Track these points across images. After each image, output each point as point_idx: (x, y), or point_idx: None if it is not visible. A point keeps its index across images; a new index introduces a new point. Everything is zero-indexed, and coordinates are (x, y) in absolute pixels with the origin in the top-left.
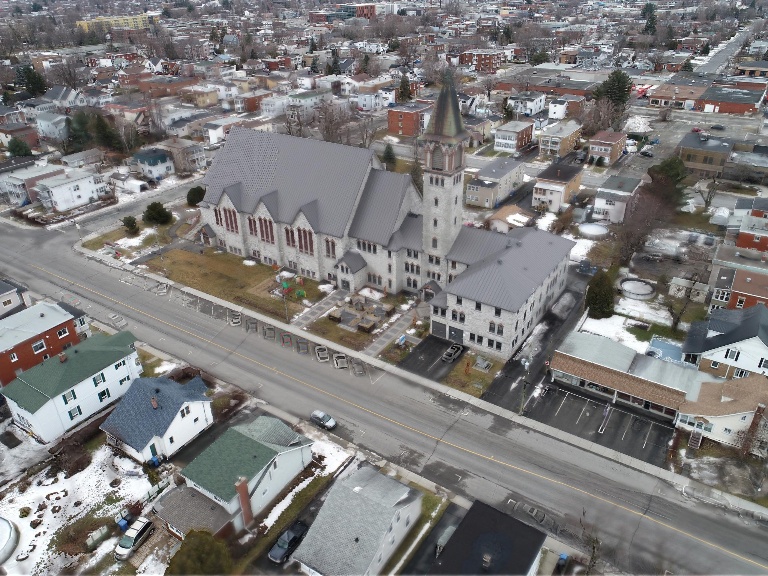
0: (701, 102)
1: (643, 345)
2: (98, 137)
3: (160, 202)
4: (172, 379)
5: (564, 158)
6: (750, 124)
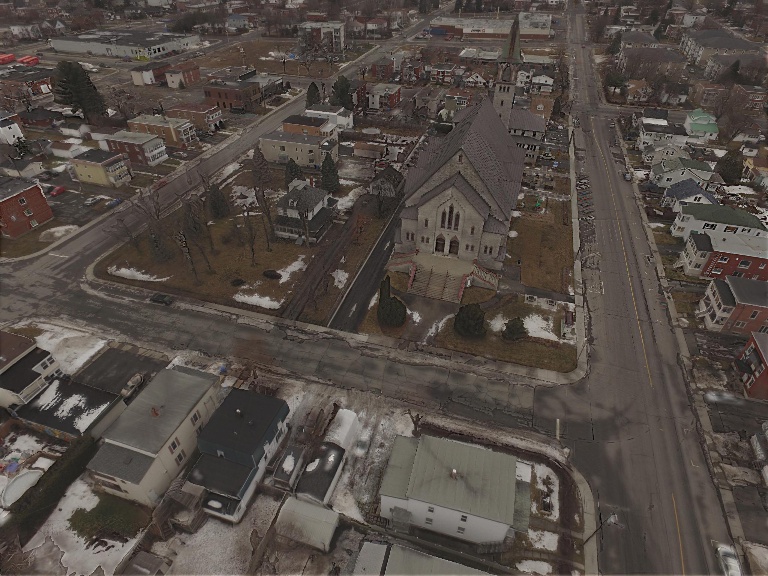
0: (35, 85)
1: None
2: None
3: (397, 367)
4: None
5: None
6: (111, 85)
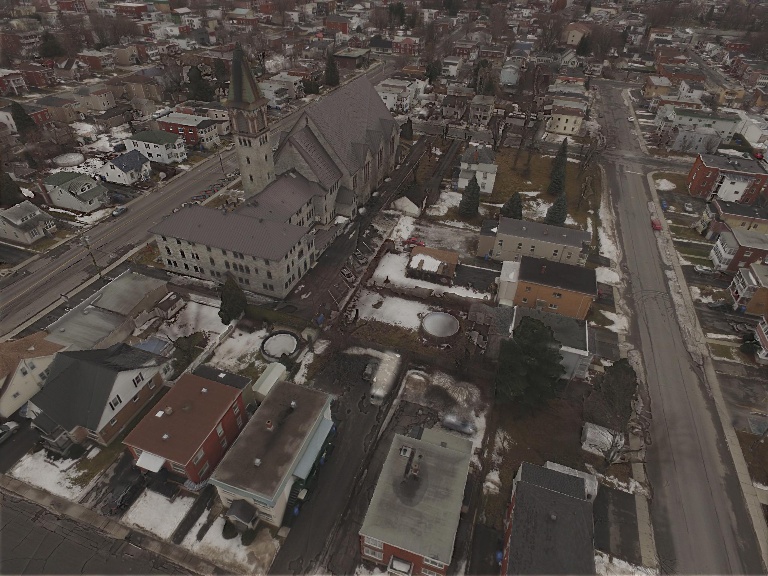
0: None
1: None
2: None
3: None
4: (164, 167)
5: (751, 316)
6: None
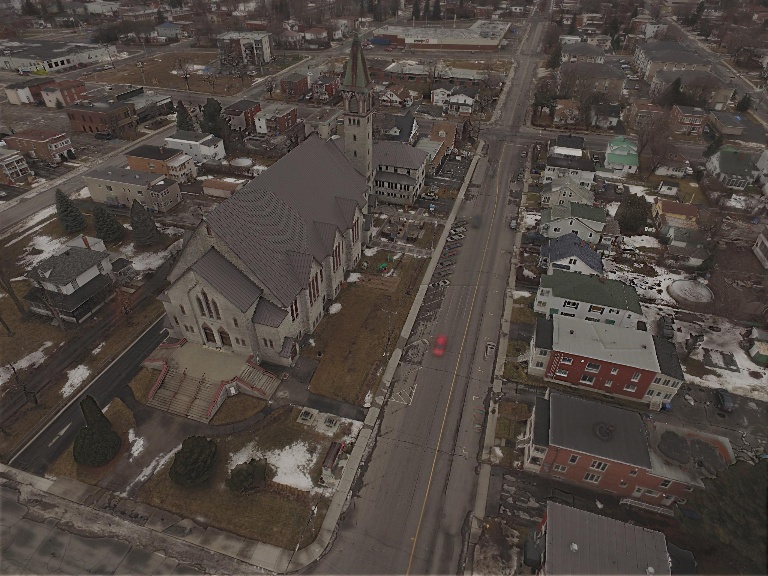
0: None
1: None
2: None
3: (59, 542)
4: None
5: None
6: None
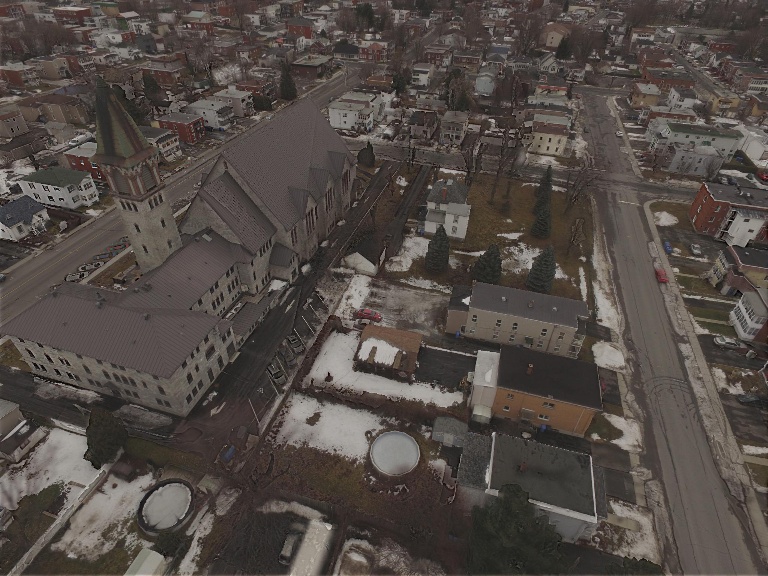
0: None
1: (8, 502)
2: (445, 92)
3: None
4: (66, 215)
5: None
6: None
